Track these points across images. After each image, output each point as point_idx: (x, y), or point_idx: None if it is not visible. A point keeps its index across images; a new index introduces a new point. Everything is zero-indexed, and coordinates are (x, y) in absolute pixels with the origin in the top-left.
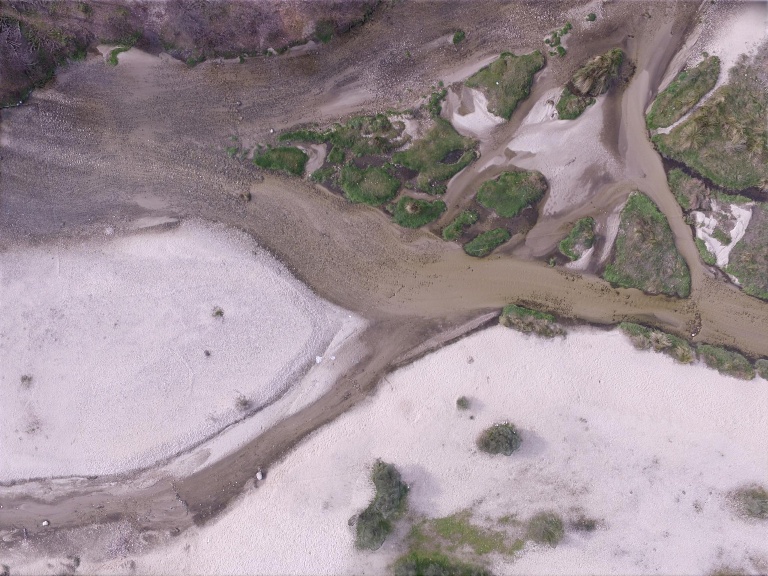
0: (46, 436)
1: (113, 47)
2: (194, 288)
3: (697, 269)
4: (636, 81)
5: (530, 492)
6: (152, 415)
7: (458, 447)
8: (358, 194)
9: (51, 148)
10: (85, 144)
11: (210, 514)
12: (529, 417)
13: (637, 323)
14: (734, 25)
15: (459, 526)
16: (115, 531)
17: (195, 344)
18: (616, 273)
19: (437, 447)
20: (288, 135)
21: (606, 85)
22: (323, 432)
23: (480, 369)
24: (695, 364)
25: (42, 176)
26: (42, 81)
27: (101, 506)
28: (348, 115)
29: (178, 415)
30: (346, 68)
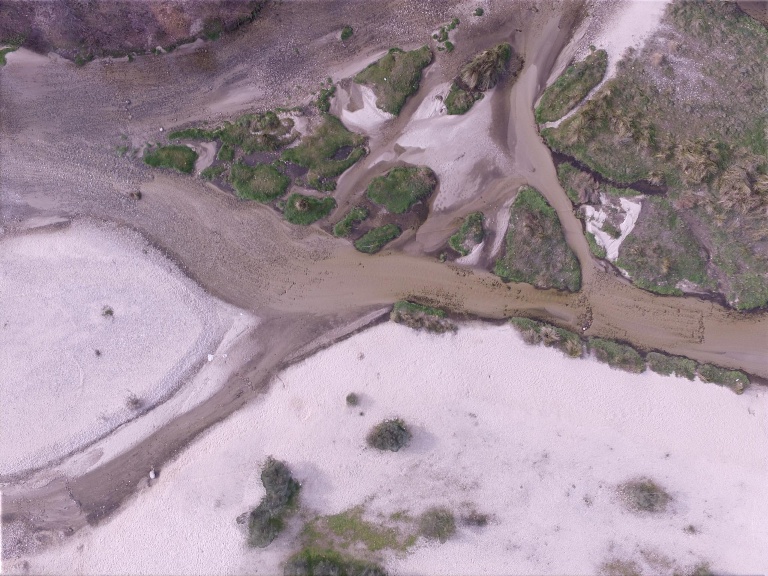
0: None
1: (1, 47)
2: (84, 287)
3: (587, 263)
4: (524, 75)
5: (421, 488)
6: (43, 415)
7: (349, 443)
8: (248, 192)
9: None
10: None
11: (104, 513)
12: (419, 413)
13: (528, 317)
14: (621, 18)
15: (351, 523)
16: (9, 531)
17: (85, 343)
18: (506, 268)
19: (328, 444)
20: (177, 133)
21: (493, 80)
22: (215, 430)
23: (370, 365)
24: (585, 358)
25: None
26: None
27: None
28: (237, 113)
29: (69, 415)
30: (235, 66)
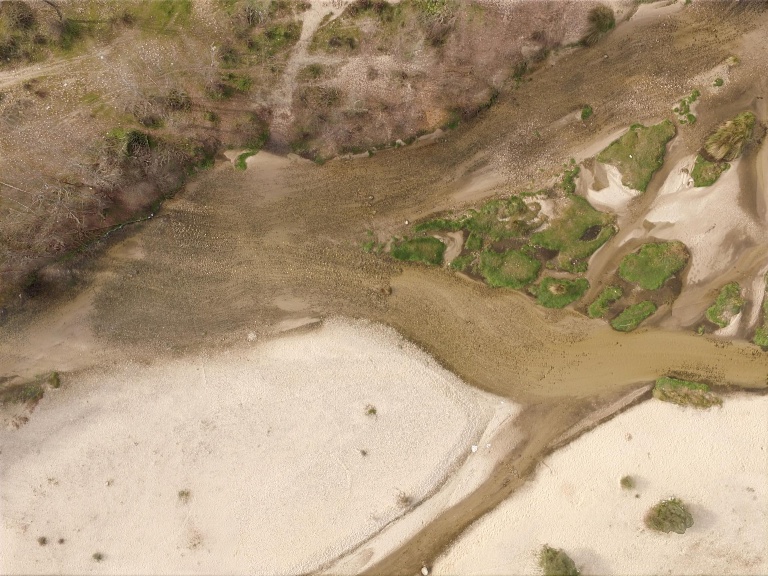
0: (208, 550)
1: (240, 152)
2: (344, 388)
3: None
4: None
5: (702, 566)
6: (313, 520)
7: (625, 527)
8: (500, 279)
9: (186, 258)
10: (220, 251)
11: None
12: (695, 491)
13: None
14: None
15: None
16: None
17: (350, 444)
18: (766, 336)
19: (604, 528)
20: (424, 226)
21: (741, 150)
22: (485, 522)
23: (640, 445)
24: None
25: (179, 287)
26: (172, 192)
27: None
28: (482, 200)
29: (339, 518)
30: (476, 153)
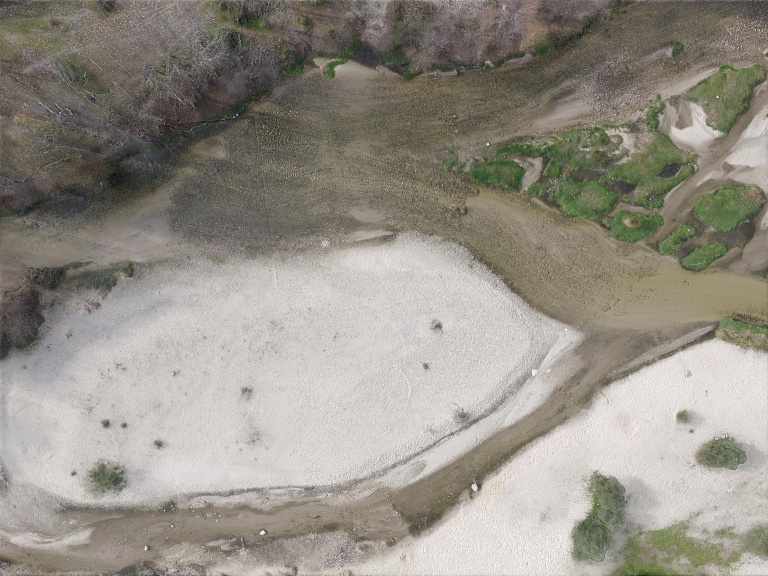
0: (266, 447)
1: (330, 60)
2: (412, 301)
3: None
4: None
5: (748, 505)
6: (371, 427)
7: (677, 460)
8: (575, 208)
9: (267, 161)
10: (301, 157)
11: (425, 525)
12: (749, 431)
13: None
14: None
15: (675, 538)
16: (332, 541)
17: (413, 357)
18: None
19: (655, 460)
20: (505, 148)
21: None
22: (538, 444)
23: (698, 383)
24: None
25: (258, 189)
26: (259, 94)
27: (317, 516)
28: (564, 128)
29: (396, 427)
30: (563, 81)
